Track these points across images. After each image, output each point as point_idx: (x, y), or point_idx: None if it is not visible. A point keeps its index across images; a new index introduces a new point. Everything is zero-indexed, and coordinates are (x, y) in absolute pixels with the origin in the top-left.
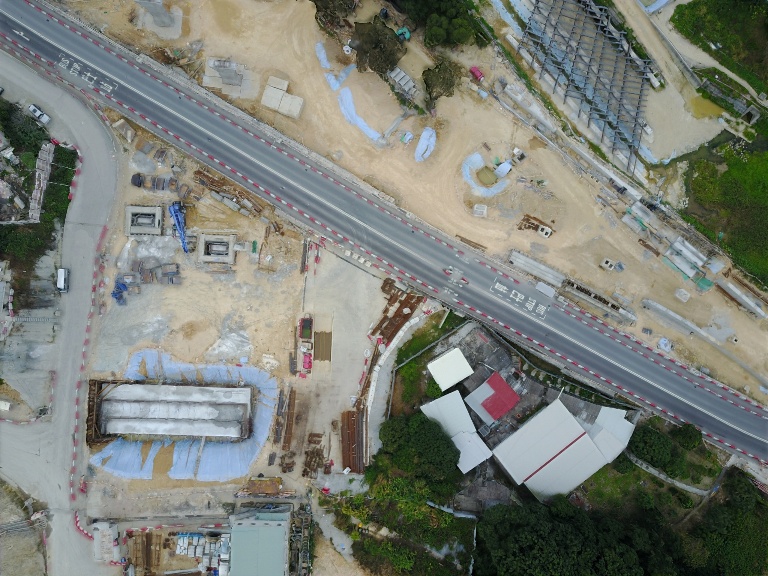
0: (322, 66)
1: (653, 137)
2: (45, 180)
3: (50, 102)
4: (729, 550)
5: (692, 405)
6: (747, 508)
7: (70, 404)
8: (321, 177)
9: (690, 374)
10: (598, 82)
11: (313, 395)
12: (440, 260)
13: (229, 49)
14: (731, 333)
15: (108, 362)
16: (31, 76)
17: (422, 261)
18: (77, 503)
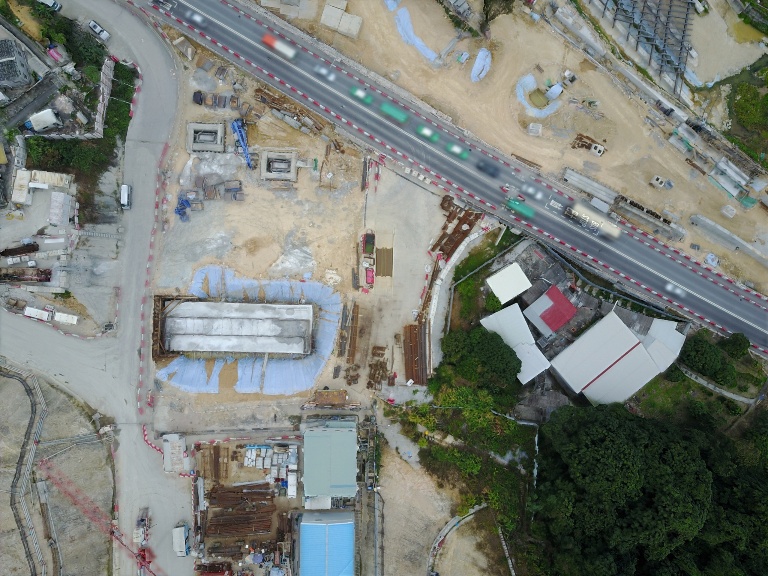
0: None
1: (698, 61)
2: (108, 95)
3: (109, 19)
4: None
5: (738, 317)
6: None
7: (135, 320)
8: (380, 96)
9: (736, 287)
10: (646, 6)
11: (376, 310)
12: (497, 178)
13: None
14: None
15: (172, 278)
16: None
17: (479, 179)
18: (144, 418)
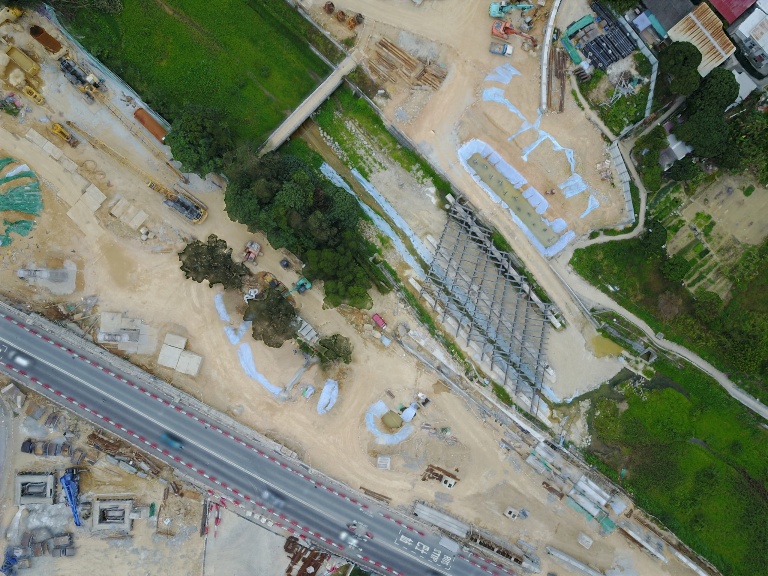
0: (222, 319)
1: (555, 377)
2: None
3: None
4: None
5: None
6: None
7: None
8: (221, 435)
9: None
10: (500, 326)
11: None
12: (344, 515)
13: (125, 304)
14: (633, 575)
15: None
16: None
17: (325, 517)
18: None
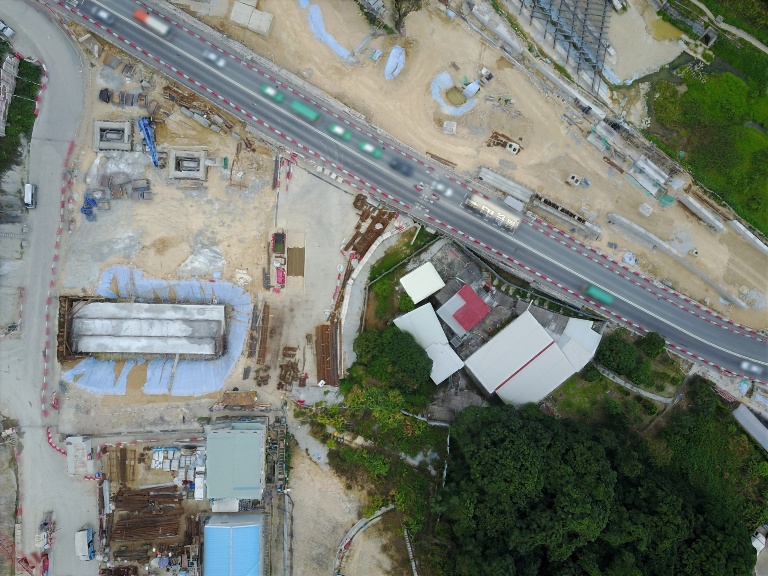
0: None
1: (616, 58)
2: (10, 93)
3: (14, 16)
4: (692, 453)
5: (656, 316)
6: (708, 411)
7: (40, 321)
8: (292, 94)
9: (653, 286)
10: (563, 4)
11: (287, 310)
12: (411, 176)
13: None
14: (692, 246)
15: (78, 279)
16: None
17: (393, 177)
18: (49, 420)
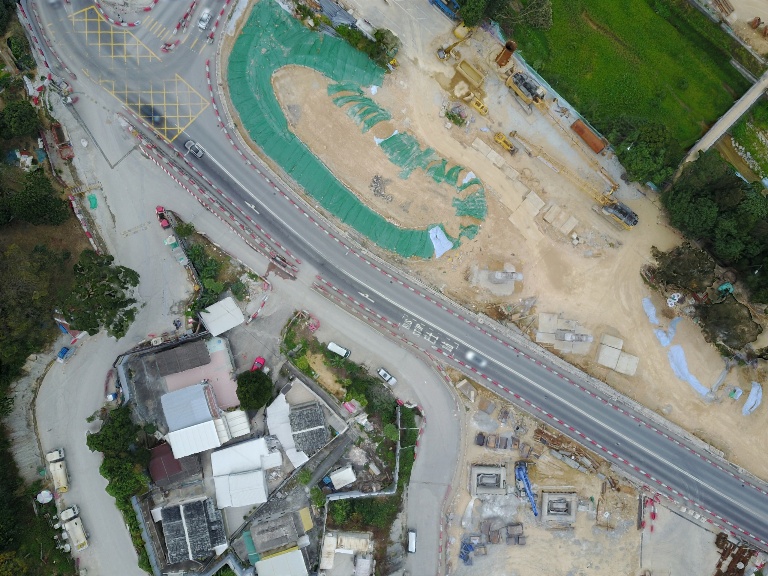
0: (650, 321)
1: None
2: (400, 447)
3: (394, 362)
4: None
5: None
6: None
7: None
8: (654, 433)
9: None
10: None
11: None
12: None
13: (561, 306)
14: None
15: None
16: (376, 337)
17: (752, 515)
18: None
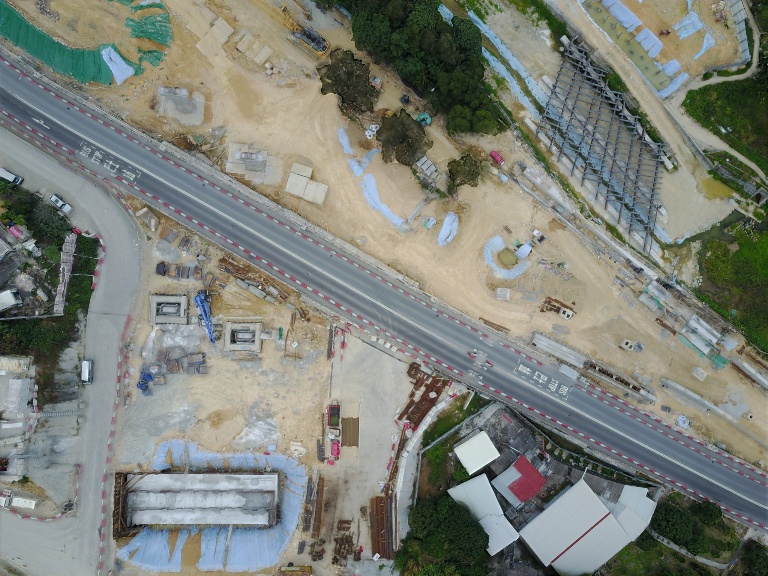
0: (345, 152)
1: (667, 217)
2: (69, 272)
3: (72, 191)
4: None
5: (710, 480)
6: None
7: (95, 498)
8: (346, 263)
9: (708, 450)
10: (614, 165)
11: (341, 481)
12: (464, 343)
13: (252, 135)
14: (746, 409)
15: (134, 454)
16: (52, 165)
17: (447, 345)
18: None
